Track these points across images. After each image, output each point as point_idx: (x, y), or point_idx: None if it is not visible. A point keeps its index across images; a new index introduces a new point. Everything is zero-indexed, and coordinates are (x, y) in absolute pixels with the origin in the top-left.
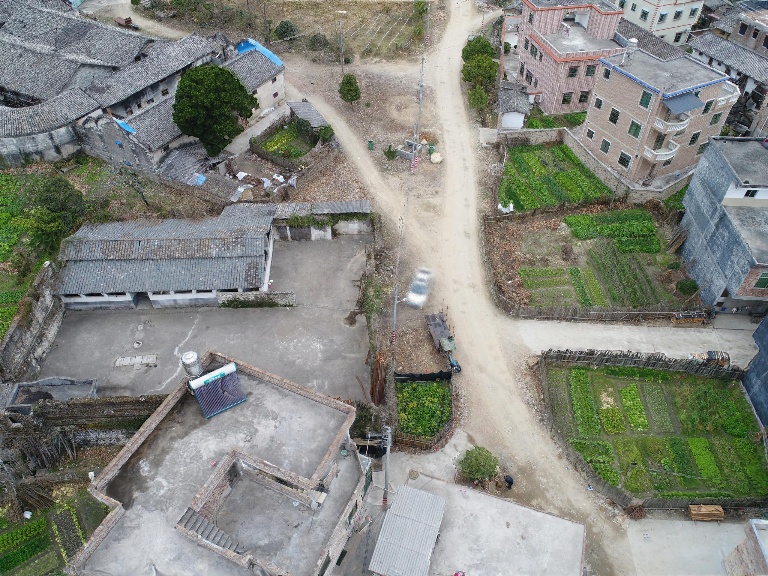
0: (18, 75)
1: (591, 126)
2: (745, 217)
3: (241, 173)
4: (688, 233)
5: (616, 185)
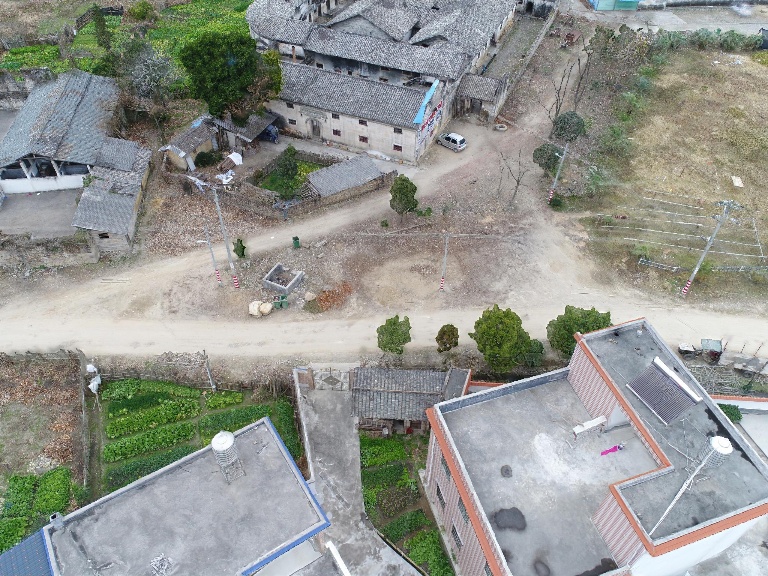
0: (360, 3)
1: None
2: None
3: (232, 154)
4: None
5: None
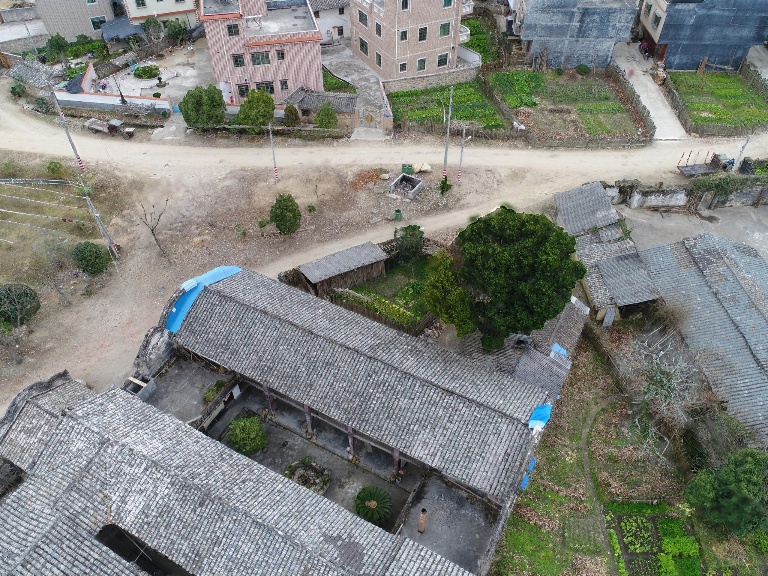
0: None
1: (402, 60)
2: (587, 4)
3: None
4: (548, 49)
5: (465, 76)
